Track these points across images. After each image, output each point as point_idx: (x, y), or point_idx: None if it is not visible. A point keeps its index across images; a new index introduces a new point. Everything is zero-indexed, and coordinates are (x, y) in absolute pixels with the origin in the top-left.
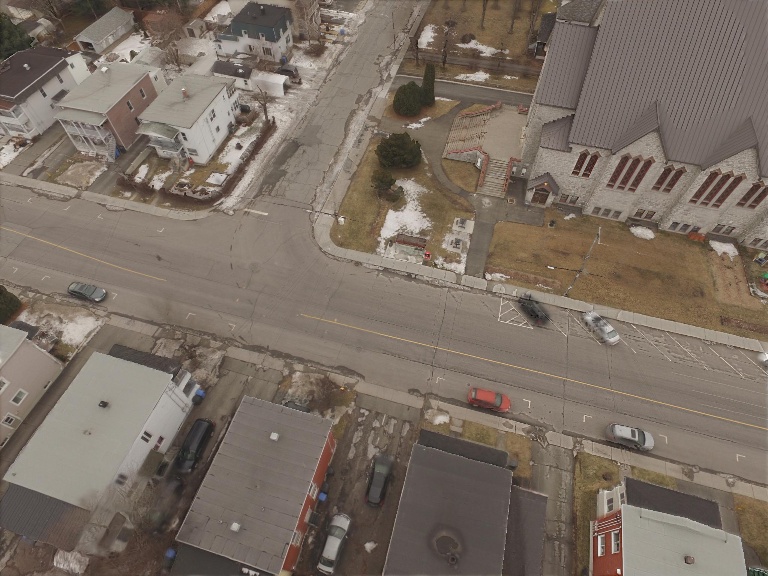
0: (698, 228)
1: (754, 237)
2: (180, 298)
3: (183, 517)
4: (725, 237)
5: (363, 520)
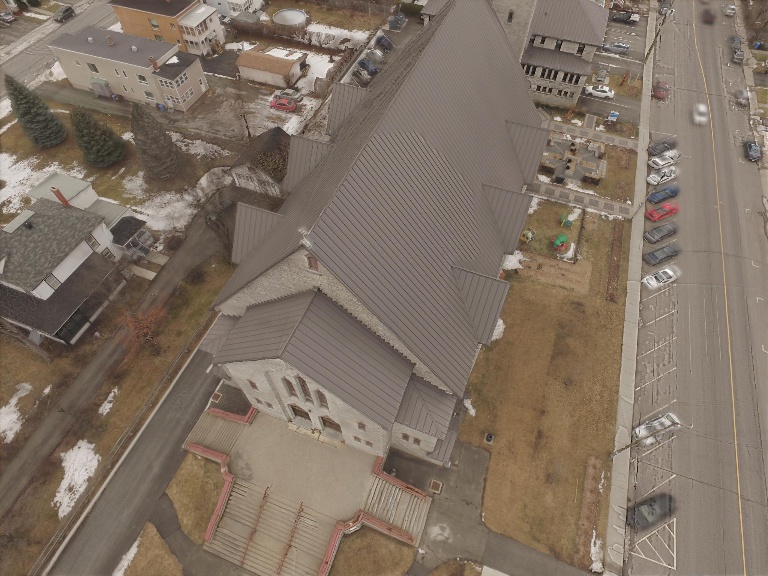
0: None
1: None
2: None
3: None
4: None
5: None
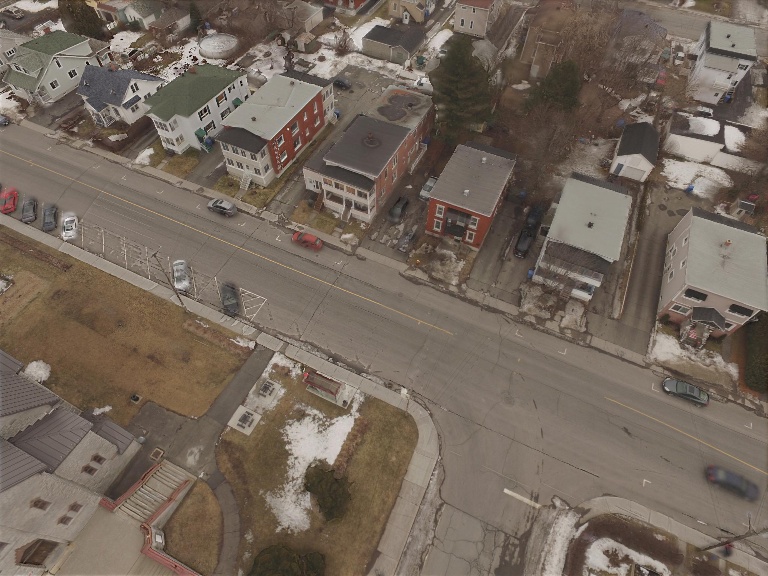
0: None
1: None
2: (581, 373)
3: (522, 212)
4: None
5: (412, 197)
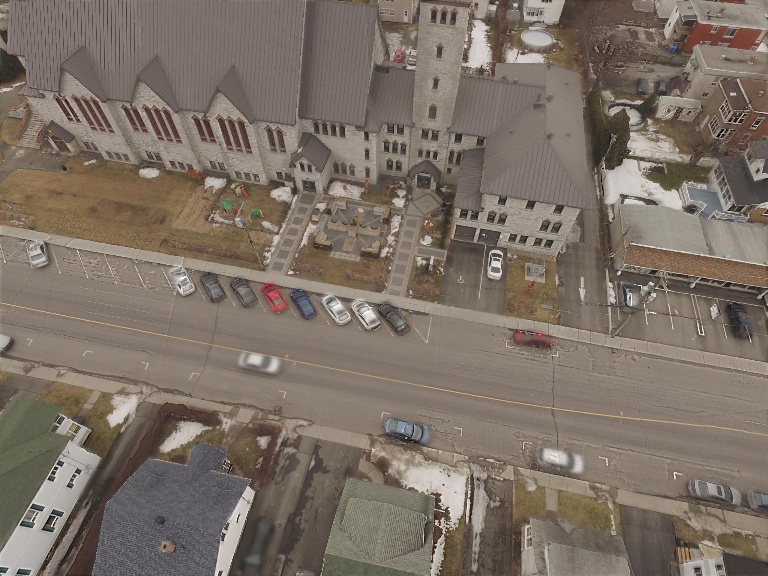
0: (191, 165)
1: (233, 170)
2: None
3: None
4: (224, 173)
5: None
